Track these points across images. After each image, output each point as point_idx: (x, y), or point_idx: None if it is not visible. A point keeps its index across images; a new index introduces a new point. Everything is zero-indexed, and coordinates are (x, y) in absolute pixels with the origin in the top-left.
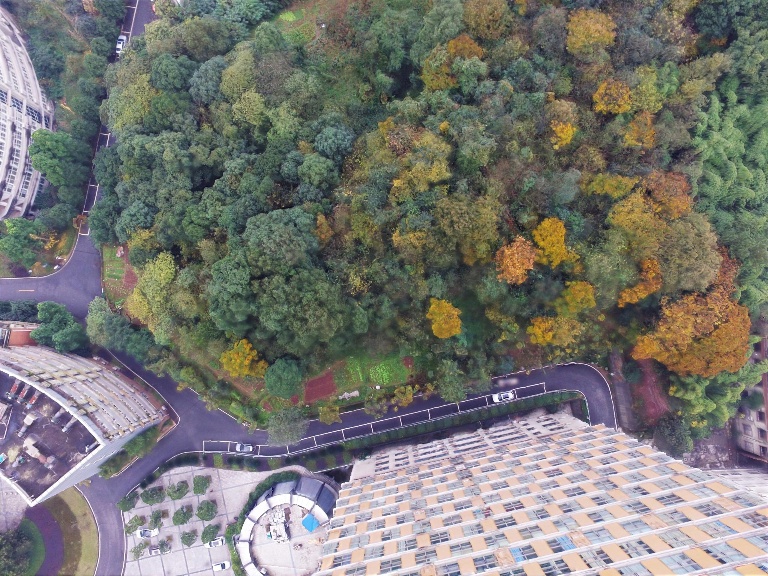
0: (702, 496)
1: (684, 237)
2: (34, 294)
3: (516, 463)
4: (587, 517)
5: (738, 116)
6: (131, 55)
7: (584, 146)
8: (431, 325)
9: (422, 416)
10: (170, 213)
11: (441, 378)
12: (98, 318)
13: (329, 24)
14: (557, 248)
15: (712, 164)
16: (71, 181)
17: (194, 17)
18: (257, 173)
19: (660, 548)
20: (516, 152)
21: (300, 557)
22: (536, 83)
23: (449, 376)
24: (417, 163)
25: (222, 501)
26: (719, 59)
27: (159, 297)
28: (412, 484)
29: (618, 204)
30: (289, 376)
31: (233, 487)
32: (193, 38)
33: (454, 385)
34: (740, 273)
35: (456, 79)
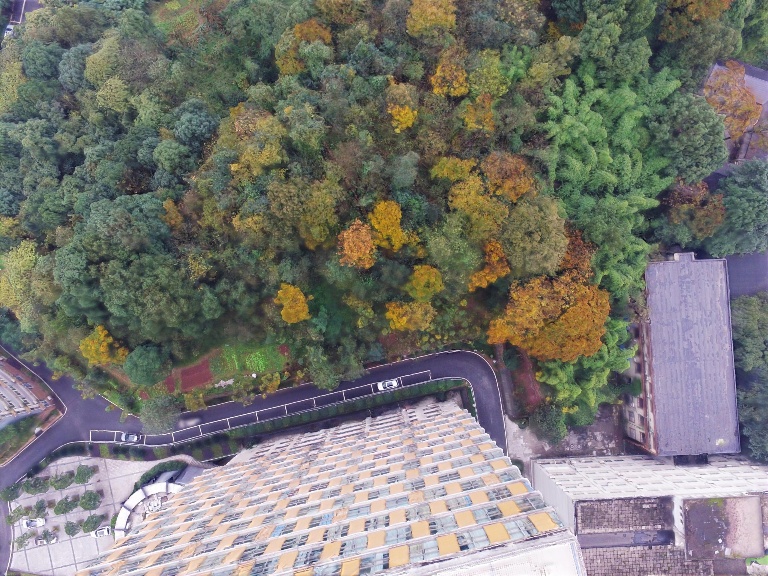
0: (478, 473)
1: (527, 220)
2: None
3: (361, 447)
4: (367, 495)
5: (594, 100)
6: (11, 44)
7: (424, 129)
8: None
9: (307, 404)
10: (28, 200)
11: (311, 365)
12: None
13: (207, 12)
14: (394, 231)
15: (573, 149)
16: None
17: (73, 5)
18: (115, 160)
19: (395, 522)
20: None
21: None
22: (383, 67)
23: (314, 363)
24: None
25: (109, 491)
26: (566, 42)
27: (20, 285)
28: (259, 469)
29: (456, 187)
30: (144, 362)
31: (120, 477)
32: (63, 25)
33: (324, 372)
34: (601, 258)
35: (304, 63)
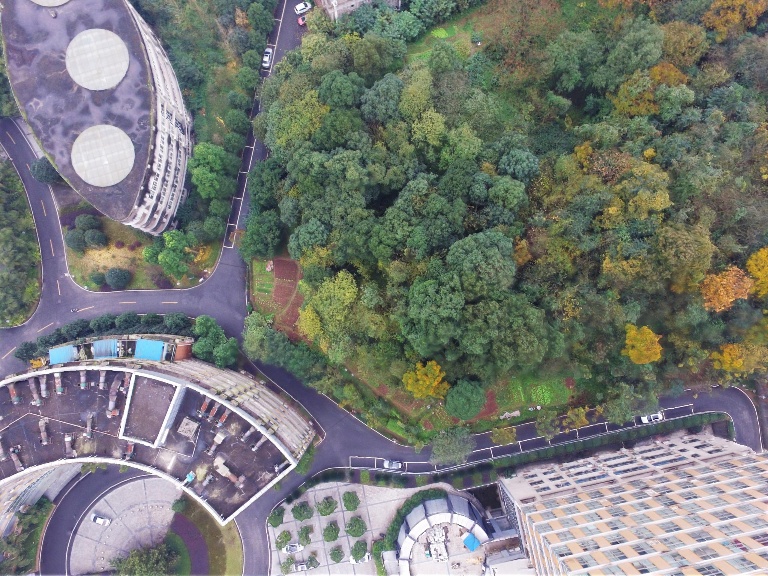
0: None
1: None
2: (178, 306)
3: (717, 490)
4: None
5: None
6: (288, 69)
7: None
8: (620, 350)
9: (570, 435)
10: (355, 232)
11: (610, 400)
12: (258, 333)
13: (491, 43)
14: None
15: None
16: (221, 194)
17: (353, 33)
18: (444, 194)
19: None
20: (727, 181)
21: (458, 575)
22: (738, 111)
23: (624, 399)
24: (640, 192)
25: (367, 517)
26: None
27: (340, 316)
28: (610, 509)
29: None
30: (478, 398)
31: (378, 503)
32: (365, 55)
33: (622, 407)
34: None
35: (658, 106)
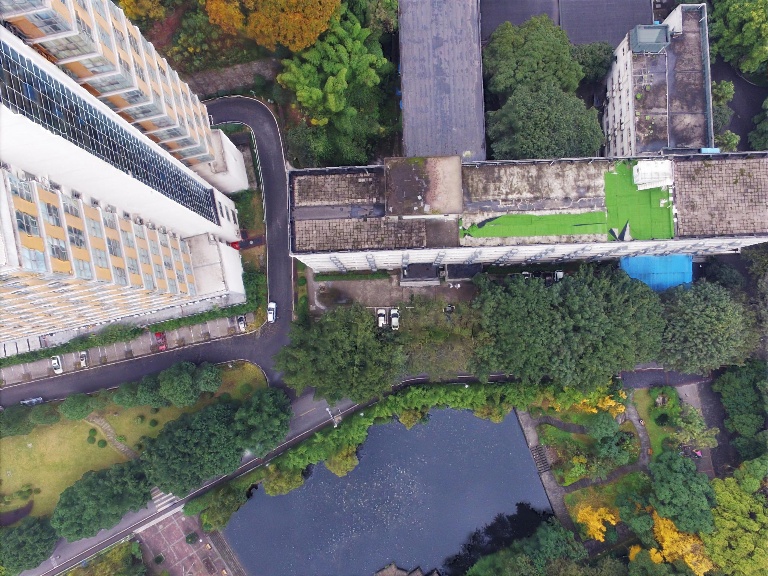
0: None
1: None
2: None
3: None
4: None
5: None
6: None
7: None
8: None
9: None
10: None
11: None
12: None
13: None
14: None
15: None
16: None
17: None
18: None
19: None
20: None
21: None
22: None
23: None
24: None
25: None
26: None
27: None
28: None
29: None
30: None
31: None
32: None
33: None
34: None
35: None
